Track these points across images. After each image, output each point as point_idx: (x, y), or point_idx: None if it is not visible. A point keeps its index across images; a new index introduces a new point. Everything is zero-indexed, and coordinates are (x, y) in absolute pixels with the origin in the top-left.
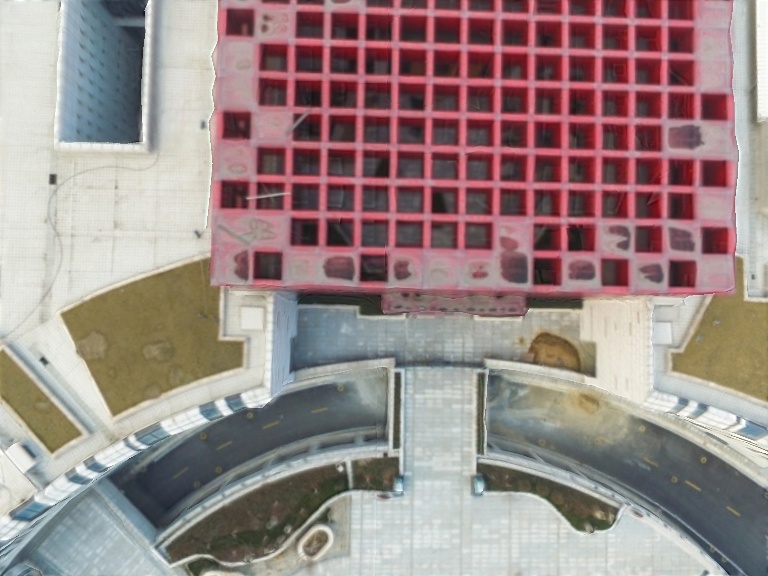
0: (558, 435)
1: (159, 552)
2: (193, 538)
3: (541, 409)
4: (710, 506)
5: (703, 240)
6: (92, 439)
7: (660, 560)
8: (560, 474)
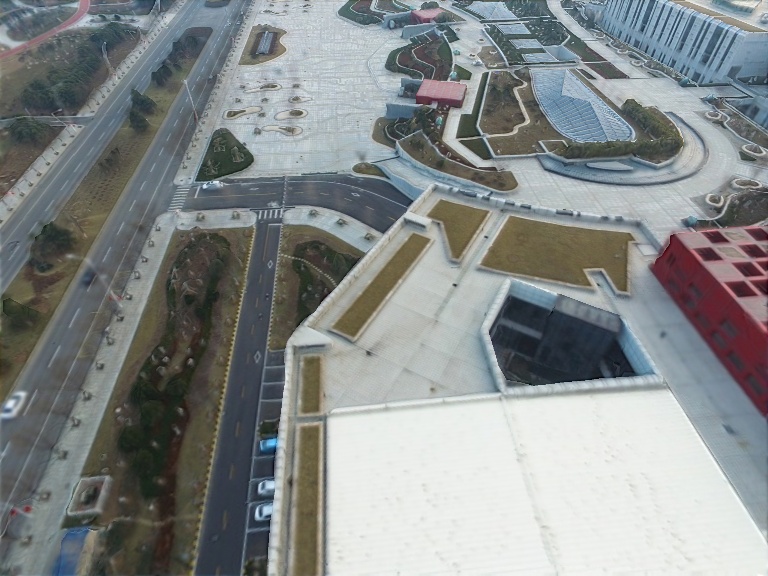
0: None
1: None
2: None
3: None
4: None
5: None
6: None
7: None
8: None
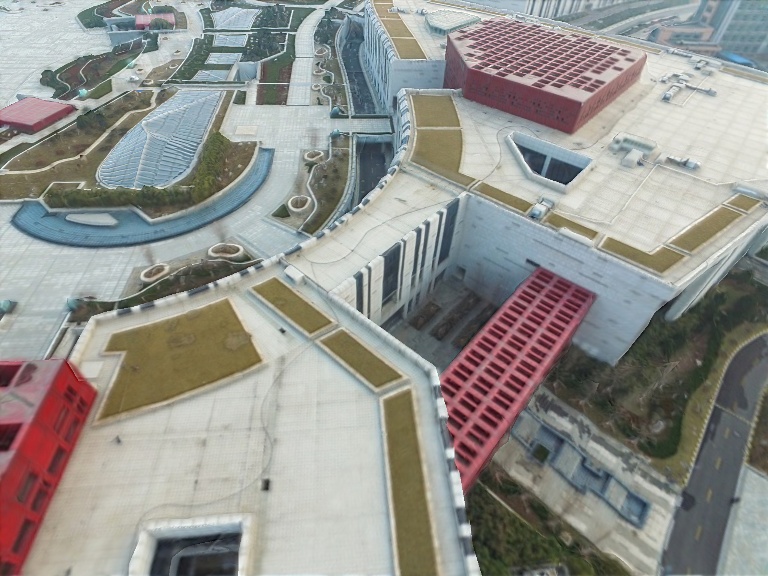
0: None
1: None
2: None
3: None
4: None
5: None
6: None
7: None
8: None
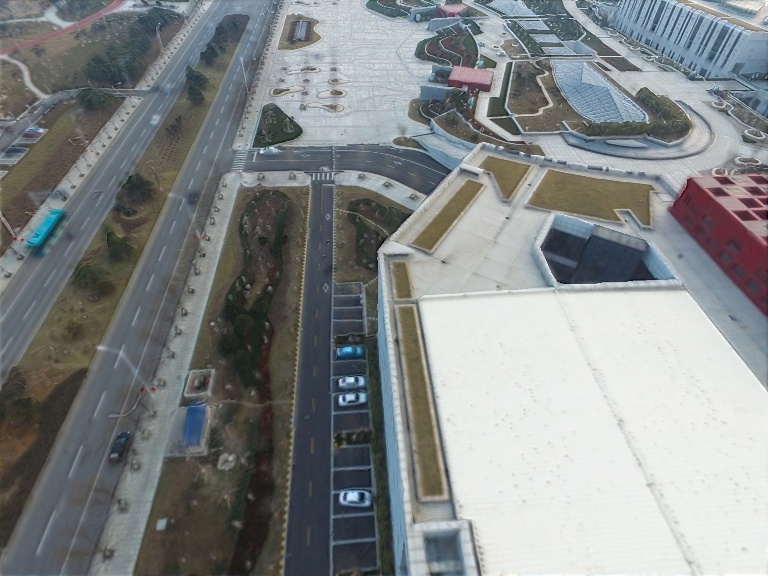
0: None
1: None
2: None
3: None
4: None
5: None
6: None
7: None
8: None
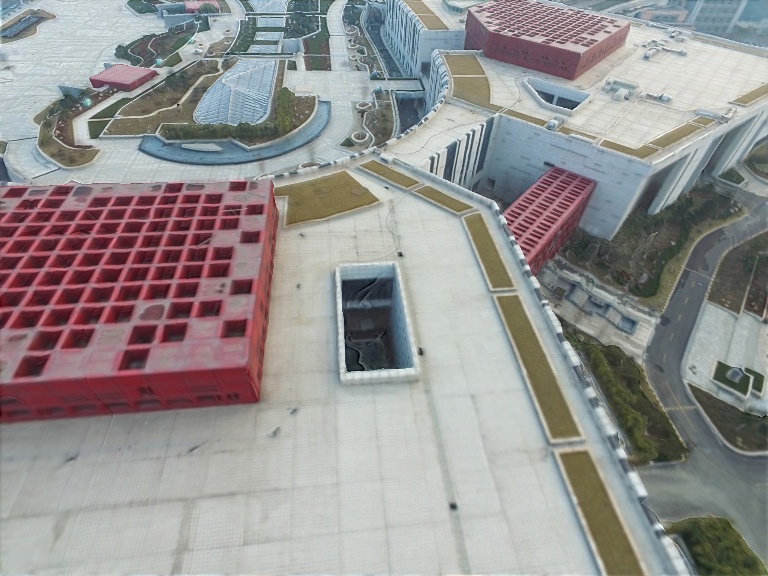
0: None
1: None
2: None
3: None
4: None
5: None
6: (355, 165)
7: (60, 181)
8: None
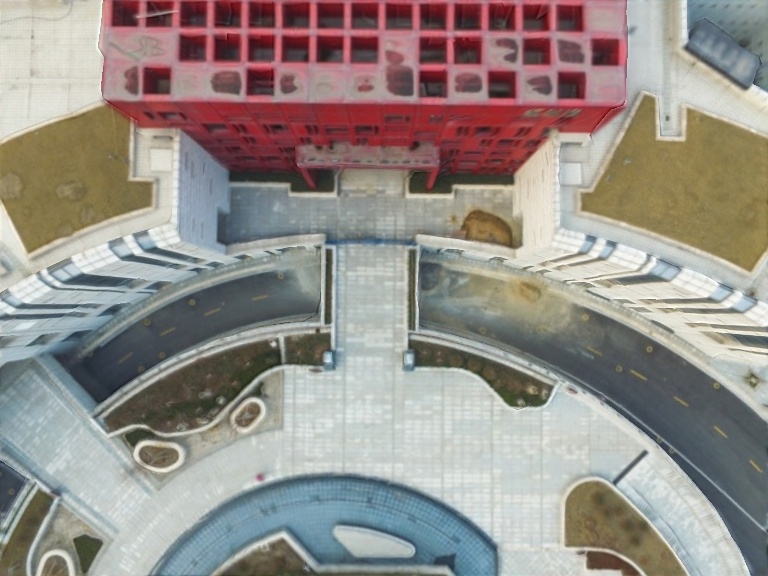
0: (499, 323)
1: (97, 422)
2: (130, 410)
3: (482, 297)
4: (657, 396)
5: (593, 52)
6: (9, 276)
7: (597, 439)
8: (493, 351)
